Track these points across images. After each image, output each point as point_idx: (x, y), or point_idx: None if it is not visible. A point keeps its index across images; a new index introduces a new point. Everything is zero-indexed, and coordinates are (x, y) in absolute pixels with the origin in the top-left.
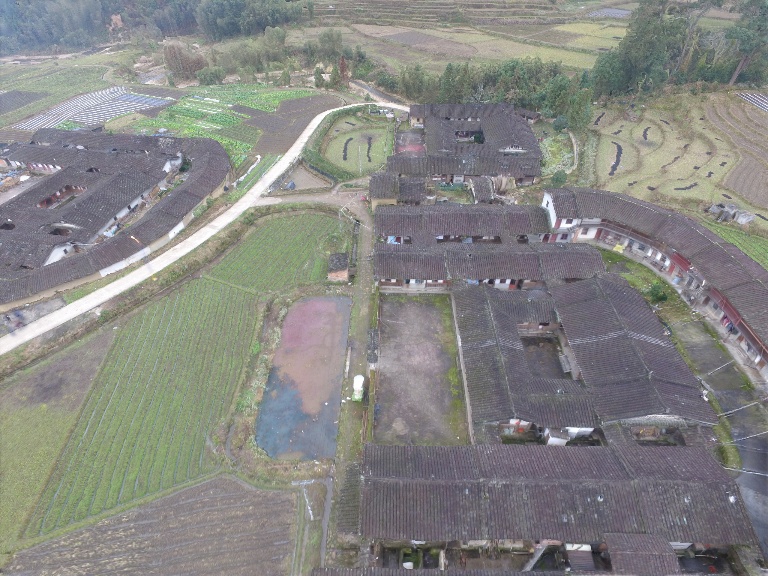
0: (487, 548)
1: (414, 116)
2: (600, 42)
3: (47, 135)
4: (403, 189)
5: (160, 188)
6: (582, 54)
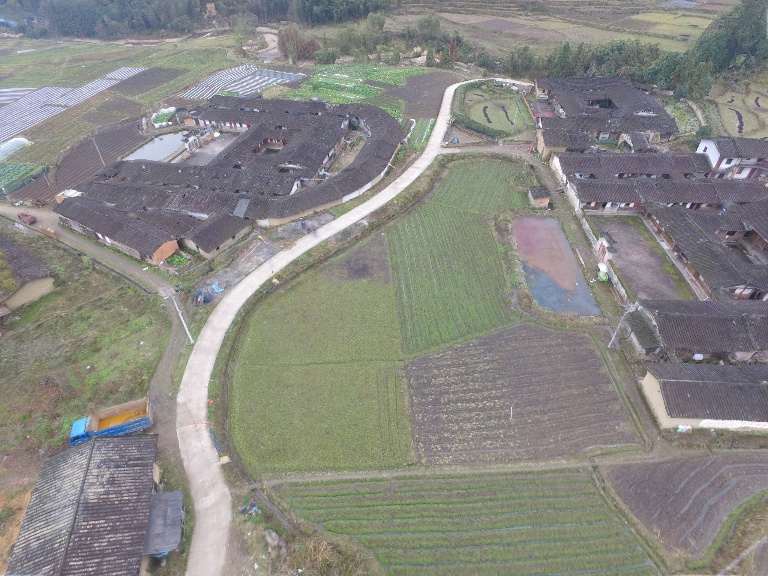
0: (749, 362)
1: (541, 88)
2: (679, 29)
3: (223, 100)
4: (570, 140)
5: (347, 141)
6: (665, 40)
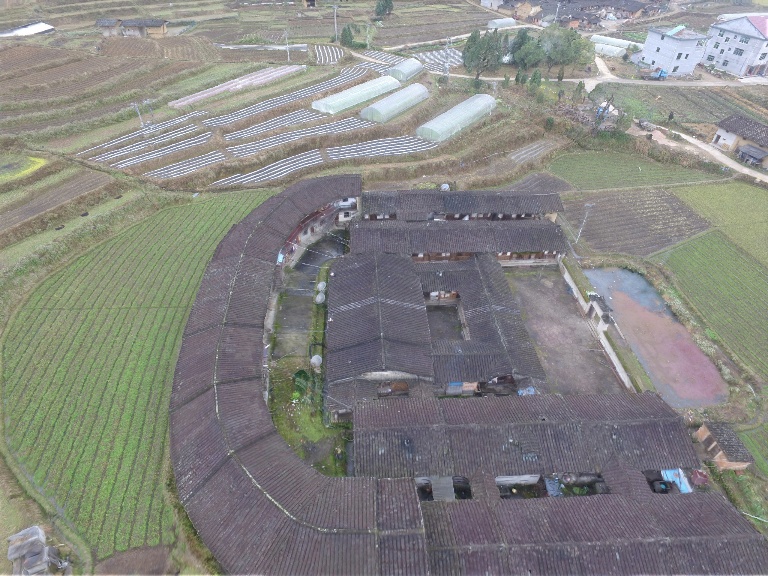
0: None
1: None
2: None
3: None
4: None
5: None
6: None
